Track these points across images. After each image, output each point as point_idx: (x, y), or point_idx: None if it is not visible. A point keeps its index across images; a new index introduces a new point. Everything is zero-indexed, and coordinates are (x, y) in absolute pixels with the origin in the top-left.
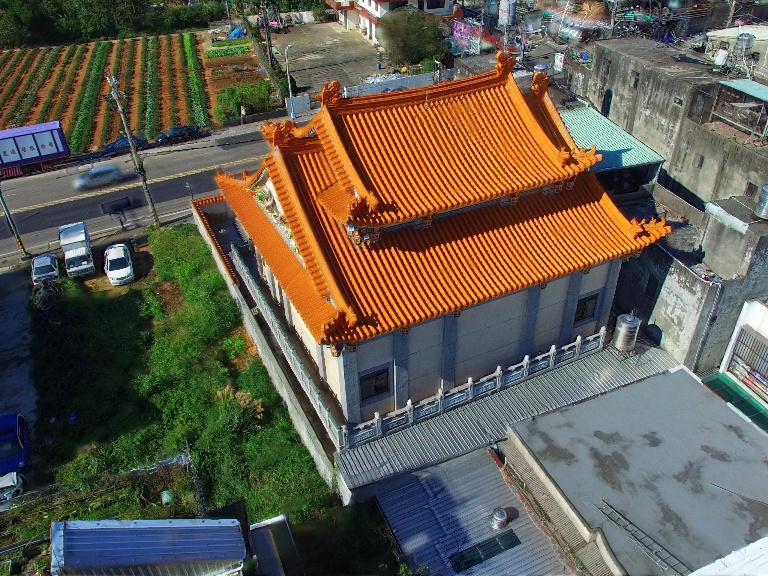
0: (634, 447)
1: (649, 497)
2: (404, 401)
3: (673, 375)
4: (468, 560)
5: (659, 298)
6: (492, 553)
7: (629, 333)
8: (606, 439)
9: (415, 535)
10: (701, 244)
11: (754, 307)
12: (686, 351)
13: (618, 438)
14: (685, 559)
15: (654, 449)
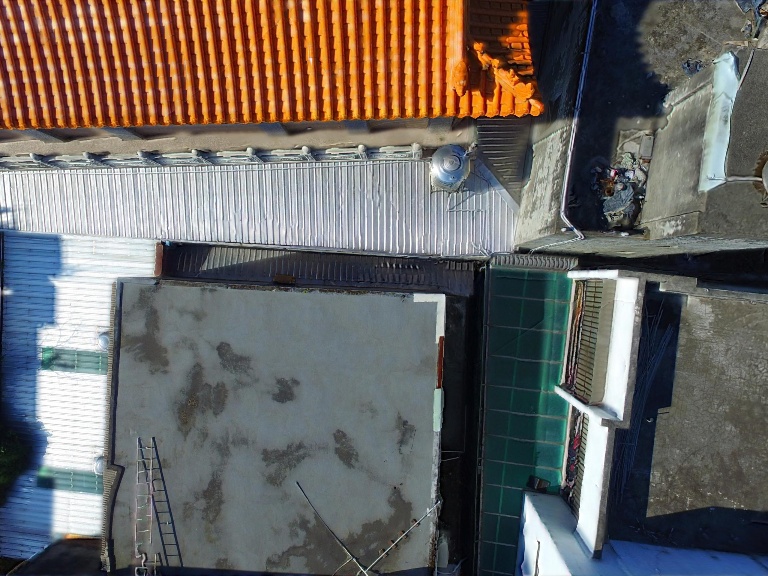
0: (251, 389)
1: (210, 461)
2: (48, 137)
3: (413, 305)
4: (60, 362)
5: (546, 140)
6: (87, 368)
7: (441, 181)
8: (227, 360)
9: (22, 305)
10: (673, 105)
11: (630, 280)
12: (520, 241)
13: (243, 367)
14: (184, 544)
15: (273, 405)
